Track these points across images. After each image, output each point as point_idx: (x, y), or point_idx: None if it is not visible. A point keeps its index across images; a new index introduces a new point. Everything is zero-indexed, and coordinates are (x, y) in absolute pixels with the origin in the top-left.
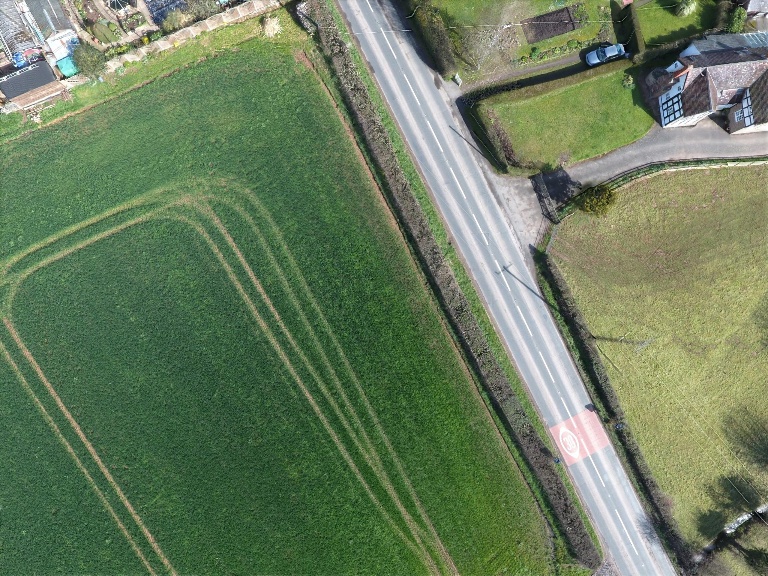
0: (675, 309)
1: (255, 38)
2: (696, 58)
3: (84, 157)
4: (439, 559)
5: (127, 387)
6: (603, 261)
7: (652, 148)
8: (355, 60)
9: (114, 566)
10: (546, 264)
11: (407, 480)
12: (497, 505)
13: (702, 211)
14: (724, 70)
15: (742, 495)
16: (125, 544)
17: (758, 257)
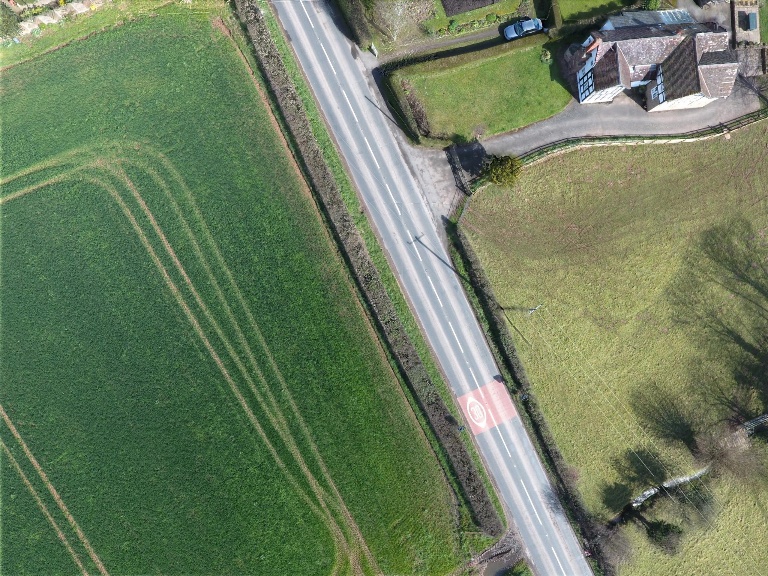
0: (587, 284)
1: (172, 3)
2: (608, 33)
3: None
4: (344, 523)
5: (35, 345)
6: (515, 234)
7: (569, 124)
8: (272, 28)
9: (19, 521)
10: (457, 235)
11: (314, 445)
12: (403, 472)
13: (617, 187)
14: (634, 45)
15: (648, 469)
16: (30, 499)
17: (672, 234)
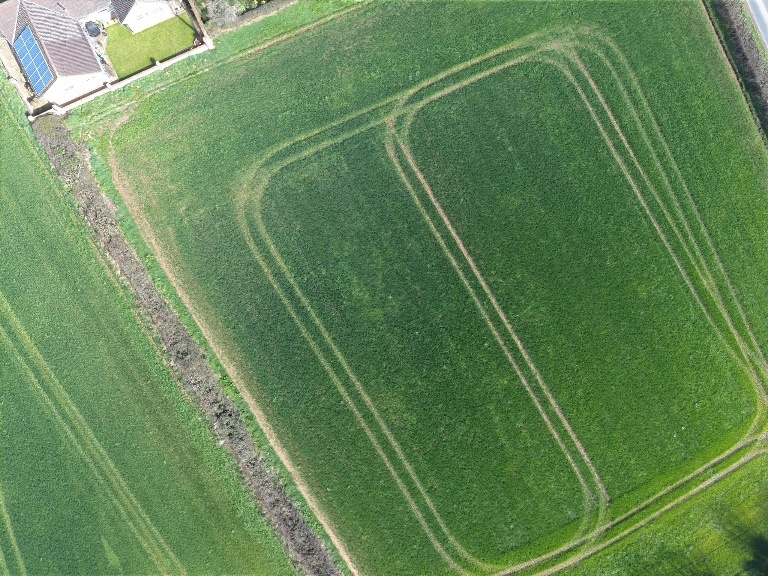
0: None
1: None
2: None
3: (470, 3)
4: (764, 377)
5: (505, 209)
6: None
7: None
8: None
9: (490, 367)
10: None
11: (739, 305)
12: None
13: None
14: None
15: None
16: (500, 348)
17: None
